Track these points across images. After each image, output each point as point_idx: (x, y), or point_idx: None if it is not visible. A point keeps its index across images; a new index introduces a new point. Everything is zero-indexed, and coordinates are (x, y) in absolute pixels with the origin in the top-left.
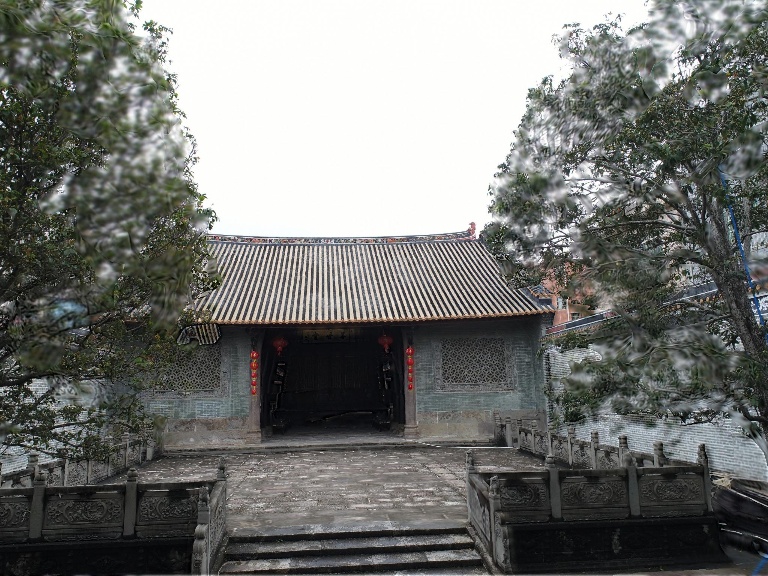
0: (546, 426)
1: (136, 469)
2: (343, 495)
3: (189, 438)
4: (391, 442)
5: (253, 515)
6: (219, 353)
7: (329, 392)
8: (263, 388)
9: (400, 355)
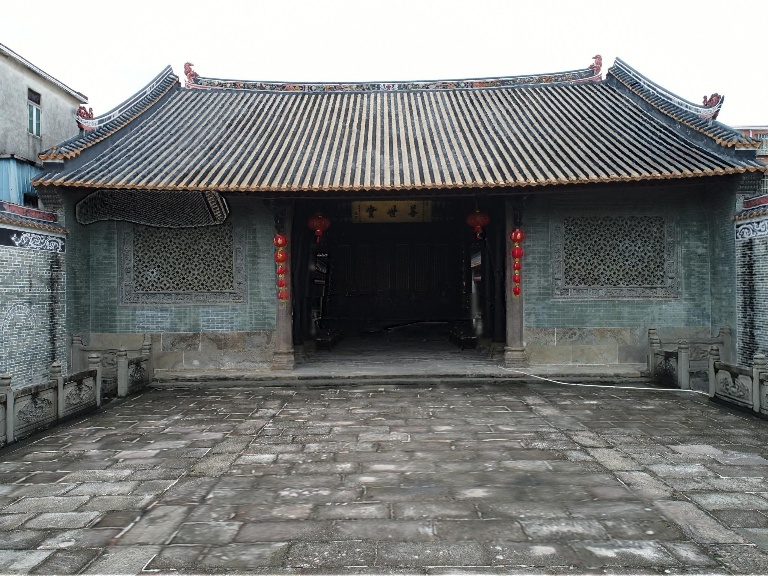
0: (734, 354)
1: (83, 418)
2: (431, 573)
3: (192, 360)
4: (487, 373)
5: None
6: (230, 238)
7: (392, 296)
8: (299, 289)
9: (500, 242)
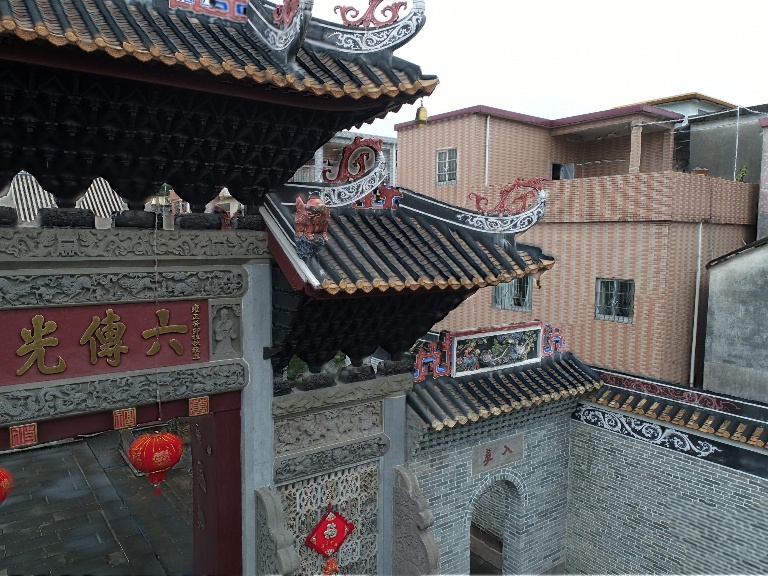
0: None
1: None
2: None
3: None
4: None
5: None
6: None
7: None
8: None
9: None
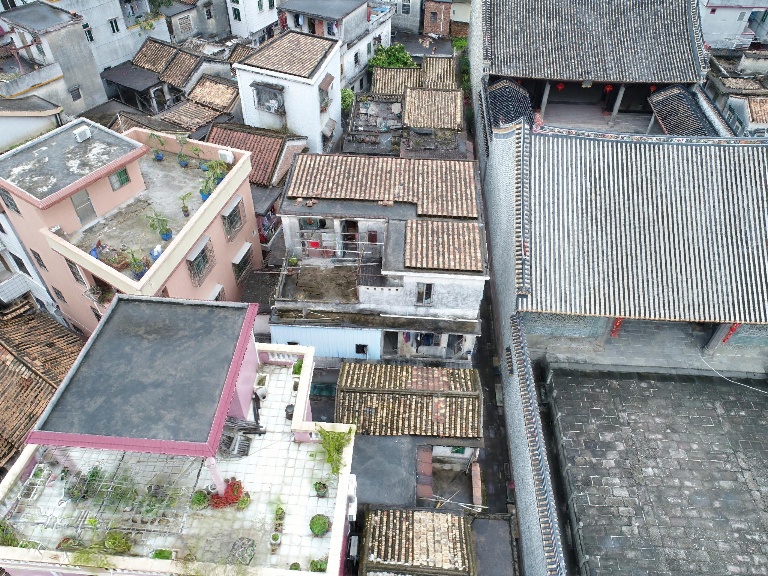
0: None
1: None
2: (717, 543)
3: (557, 344)
4: (696, 367)
5: (688, 575)
6: None
7: None
8: None
9: None
